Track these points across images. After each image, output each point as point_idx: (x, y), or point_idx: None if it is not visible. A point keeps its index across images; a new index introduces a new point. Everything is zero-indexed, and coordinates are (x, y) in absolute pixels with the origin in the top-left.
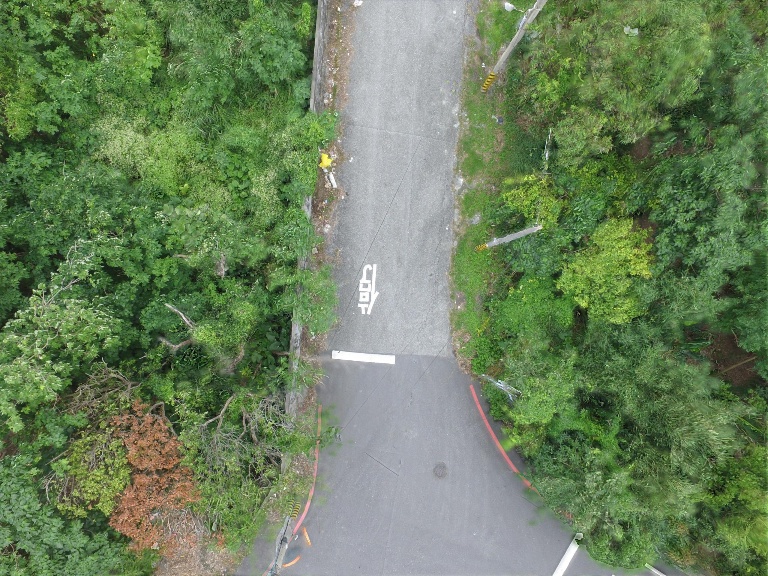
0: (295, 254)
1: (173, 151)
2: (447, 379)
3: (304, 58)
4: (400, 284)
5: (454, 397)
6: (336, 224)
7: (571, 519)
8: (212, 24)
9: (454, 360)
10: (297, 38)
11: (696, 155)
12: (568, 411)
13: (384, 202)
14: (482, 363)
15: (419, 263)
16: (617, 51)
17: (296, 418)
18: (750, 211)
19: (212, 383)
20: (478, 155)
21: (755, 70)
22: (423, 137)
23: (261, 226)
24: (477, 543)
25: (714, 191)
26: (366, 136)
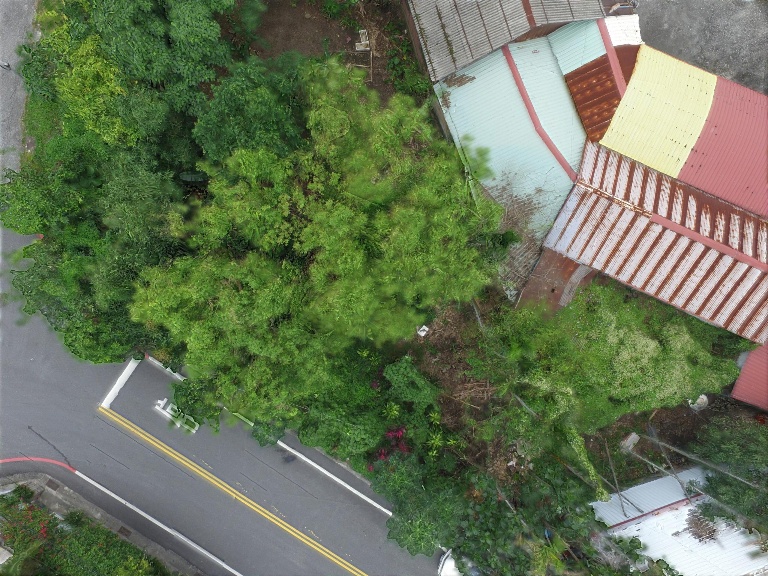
0: None
1: None
2: None
3: None
4: None
5: (20, 234)
6: None
7: (57, 320)
8: None
9: None
10: None
11: None
12: (70, 226)
13: None
14: None
15: None
16: None
17: None
18: None
19: None
20: None
21: None
22: None
23: None
24: (34, 367)
25: None
26: None
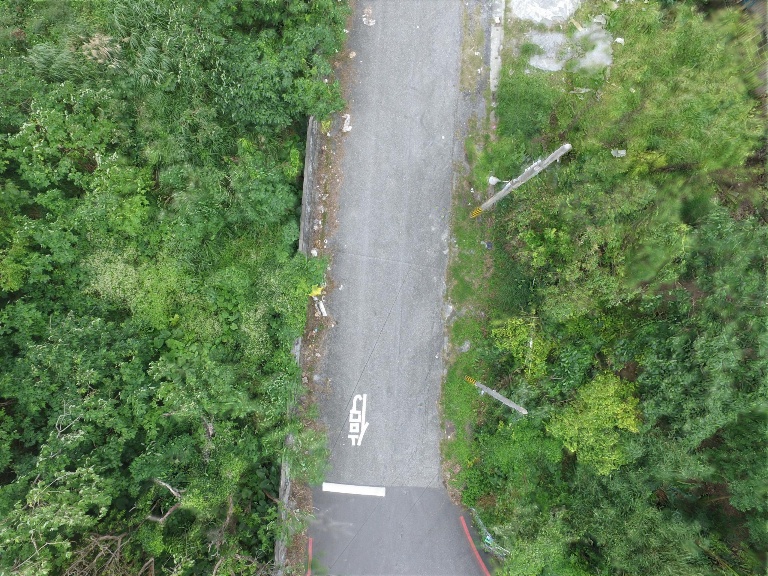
0: (284, 399)
1: (163, 285)
2: (437, 510)
3: (293, 189)
4: (390, 414)
5: (445, 529)
6: (326, 353)
7: None
8: (202, 157)
9: (444, 491)
10: (286, 180)
11: (681, 324)
12: None
13: (374, 331)
14: (472, 497)
15: (409, 393)
16: (605, 174)
17: (287, 552)
18: (735, 377)
19: (202, 531)
20: (467, 282)
21: (739, 235)
22: (412, 264)
23: (251, 366)
24: None
25: (698, 366)
26: (356, 263)
